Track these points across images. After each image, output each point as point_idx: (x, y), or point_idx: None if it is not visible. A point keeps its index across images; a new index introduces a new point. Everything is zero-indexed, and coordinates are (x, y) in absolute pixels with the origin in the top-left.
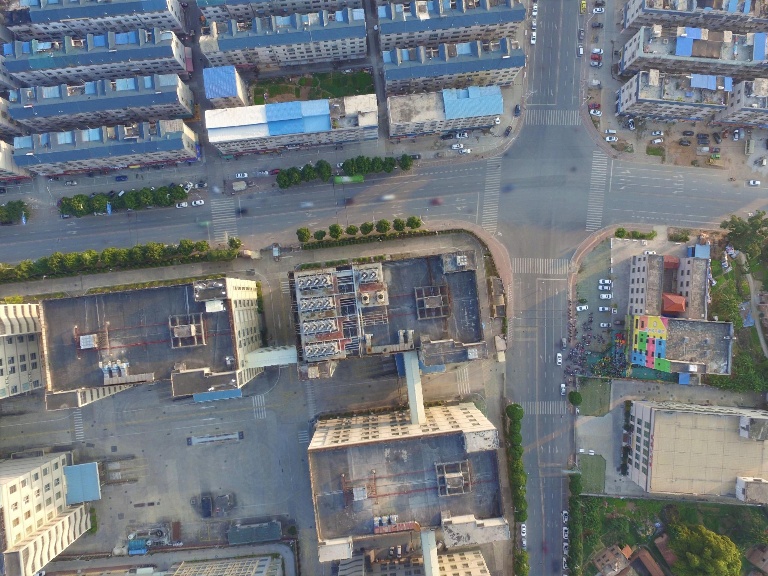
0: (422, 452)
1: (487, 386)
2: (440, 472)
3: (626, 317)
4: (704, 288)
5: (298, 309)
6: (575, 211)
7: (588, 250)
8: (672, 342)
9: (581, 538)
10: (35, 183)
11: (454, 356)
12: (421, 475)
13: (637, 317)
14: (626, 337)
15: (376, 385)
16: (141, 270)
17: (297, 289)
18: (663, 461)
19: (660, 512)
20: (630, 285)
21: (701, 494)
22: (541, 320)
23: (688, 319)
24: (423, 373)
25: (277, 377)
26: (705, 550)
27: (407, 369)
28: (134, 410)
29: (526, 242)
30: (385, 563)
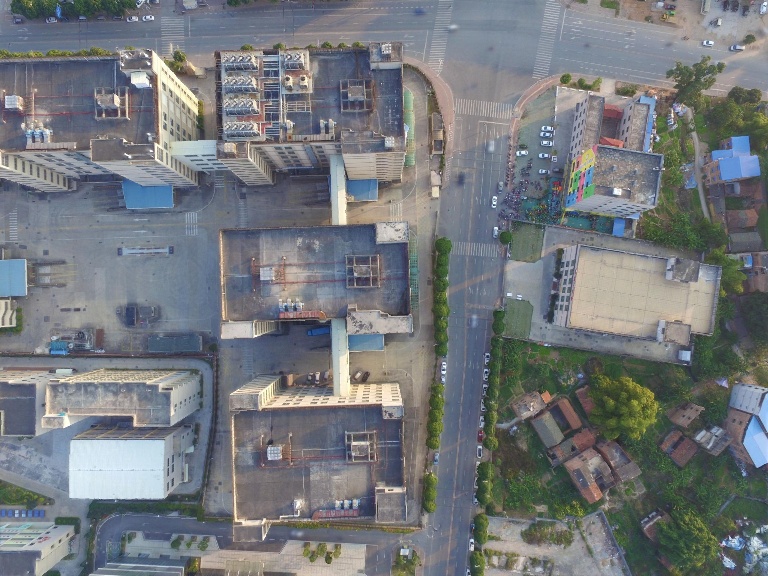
0: (334, 244)
1: (420, 223)
2: (350, 264)
3: (566, 166)
4: (643, 133)
5: (222, 89)
6: (523, 57)
7: (533, 97)
8: (600, 170)
9: (498, 373)
10: None
11: (372, 146)
12: (331, 266)
13: (574, 160)
14: (563, 183)
15: (309, 212)
16: None
17: (223, 69)
18: (585, 297)
19: (584, 364)
20: (572, 134)
21: (621, 334)
22: (480, 162)
23: (618, 147)
24: (355, 200)
25: (212, 196)
26: (622, 393)
27: (332, 175)
28: (68, 216)
29: (471, 84)
30: (302, 386)
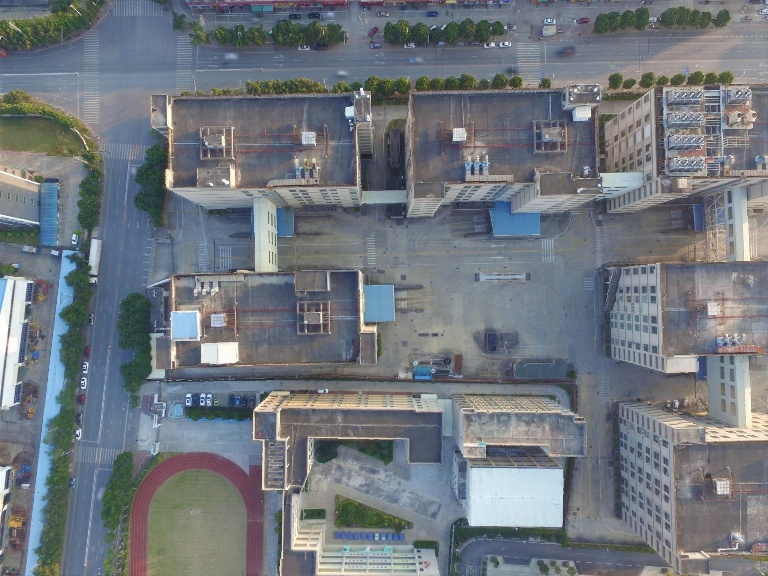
0: None
1: None
2: None
3: None
4: None
5: (663, 124)
6: None
7: None
8: None
9: None
10: (348, 11)
11: None
12: (766, 301)
13: None
14: None
15: (665, 240)
16: None
17: (664, 104)
18: None
19: None
20: None
21: None
22: None
23: None
24: None
25: (568, 223)
26: None
27: (736, 208)
28: (426, 241)
29: None
30: None
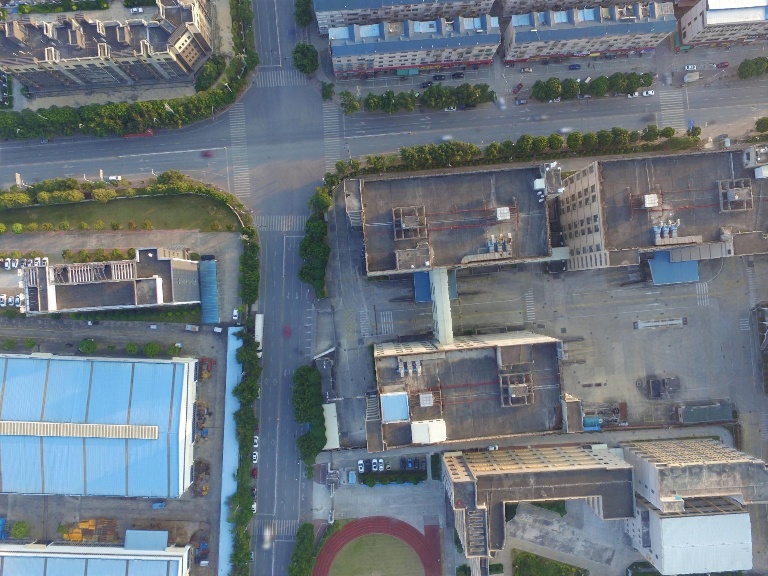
0: None
1: None
2: None
3: None
4: None
5: None
6: None
7: None
8: None
9: None
10: (491, 69)
11: None
12: None
13: None
14: None
15: None
16: (591, 158)
17: None
18: None
19: None
20: None
21: None
22: None
23: None
24: None
25: (720, 266)
26: None
27: None
28: (583, 293)
29: None
30: None
